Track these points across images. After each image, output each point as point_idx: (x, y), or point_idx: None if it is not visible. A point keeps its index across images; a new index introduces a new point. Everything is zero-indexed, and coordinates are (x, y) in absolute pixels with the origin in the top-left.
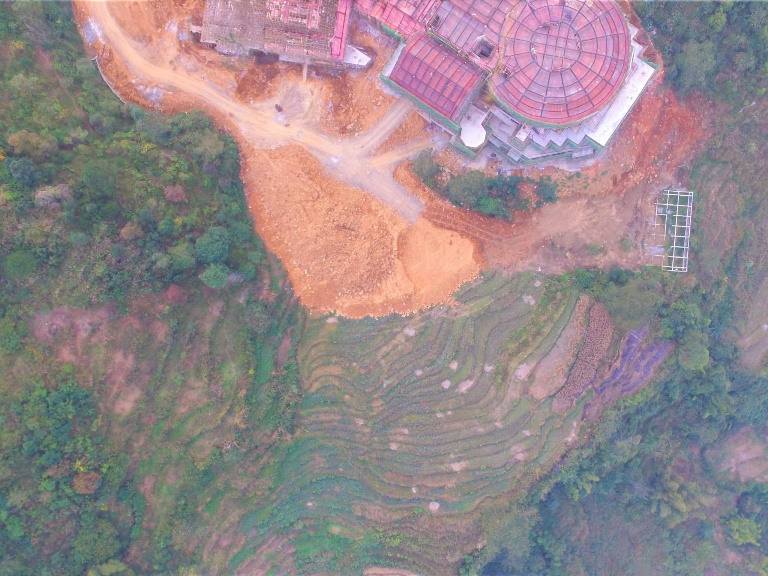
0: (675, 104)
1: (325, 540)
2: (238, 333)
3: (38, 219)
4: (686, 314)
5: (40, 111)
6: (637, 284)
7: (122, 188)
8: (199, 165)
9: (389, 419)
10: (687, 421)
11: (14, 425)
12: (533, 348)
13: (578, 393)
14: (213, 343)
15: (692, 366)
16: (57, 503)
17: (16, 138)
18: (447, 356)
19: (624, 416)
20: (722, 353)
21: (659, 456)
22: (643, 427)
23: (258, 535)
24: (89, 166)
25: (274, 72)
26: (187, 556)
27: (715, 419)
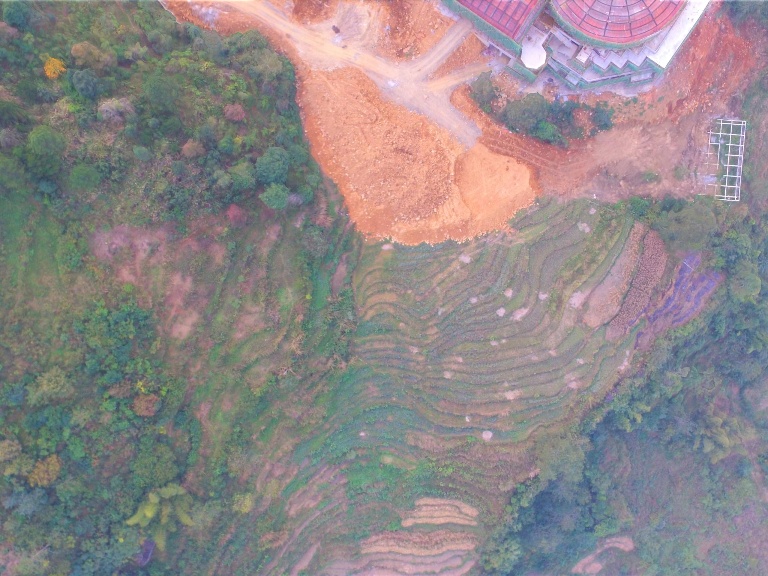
0: (731, 31)
1: (377, 470)
2: (295, 257)
3: (100, 133)
4: (738, 243)
5: (97, 26)
6: (694, 209)
7: (182, 105)
8: (257, 85)
9: (443, 347)
10: (729, 358)
11: (76, 343)
12: (588, 276)
13: (632, 321)
14: (270, 268)
15: (742, 297)
16: (117, 425)
17: (80, 47)
18: (502, 283)
19: (674, 347)
20: (767, 288)
21: (701, 393)
22: (687, 363)
23: (311, 465)
24: (153, 78)
25: None
26: (241, 485)
27: (758, 355)
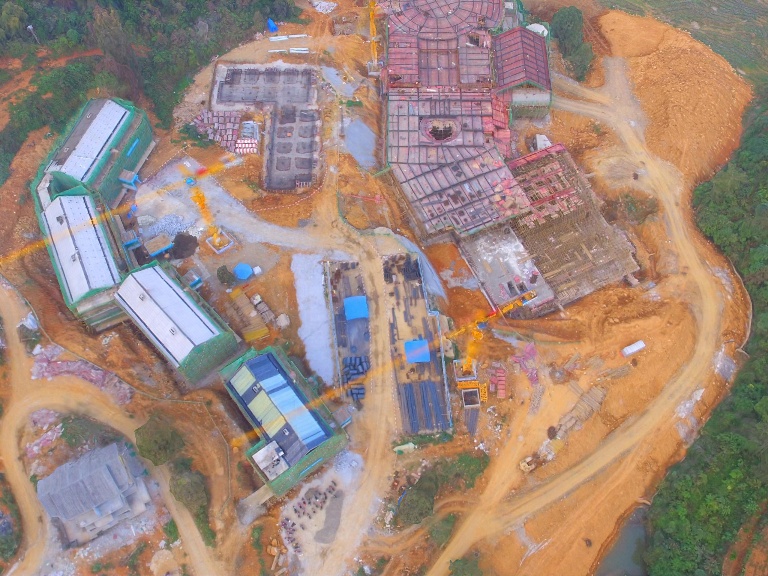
0: None
1: None
2: None
3: None
4: None
5: None
6: None
7: None
8: None
9: (763, 10)
10: None
11: None
12: None
13: None
14: None
15: None
16: None
17: None
18: None
19: None
20: None
21: None
22: None
23: None
24: None
25: None
26: None
27: None
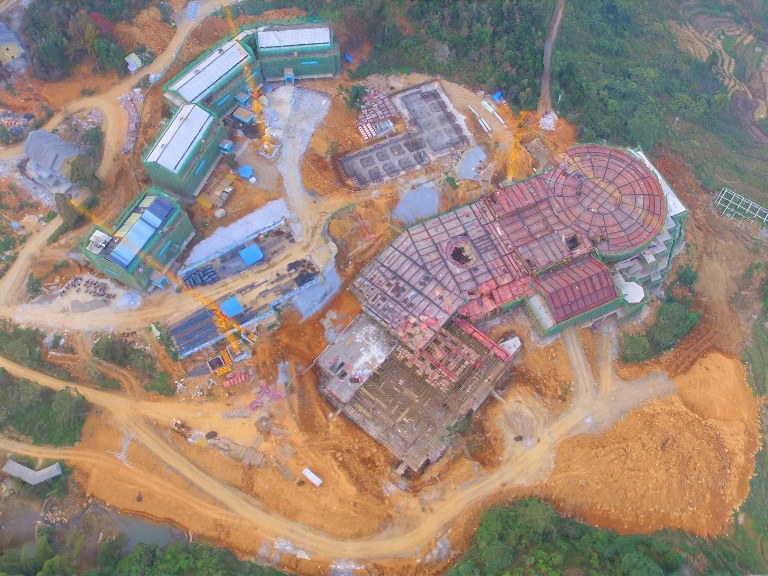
0: (654, 162)
1: None
2: None
3: None
4: None
5: None
6: None
7: None
8: (547, 542)
9: None
10: None
11: None
12: None
13: None
14: None
15: None
16: None
17: None
18: None
19: None
20: None
21: None
22: None
23: None
24: None
25: (480, 425)
26: None
27: None
